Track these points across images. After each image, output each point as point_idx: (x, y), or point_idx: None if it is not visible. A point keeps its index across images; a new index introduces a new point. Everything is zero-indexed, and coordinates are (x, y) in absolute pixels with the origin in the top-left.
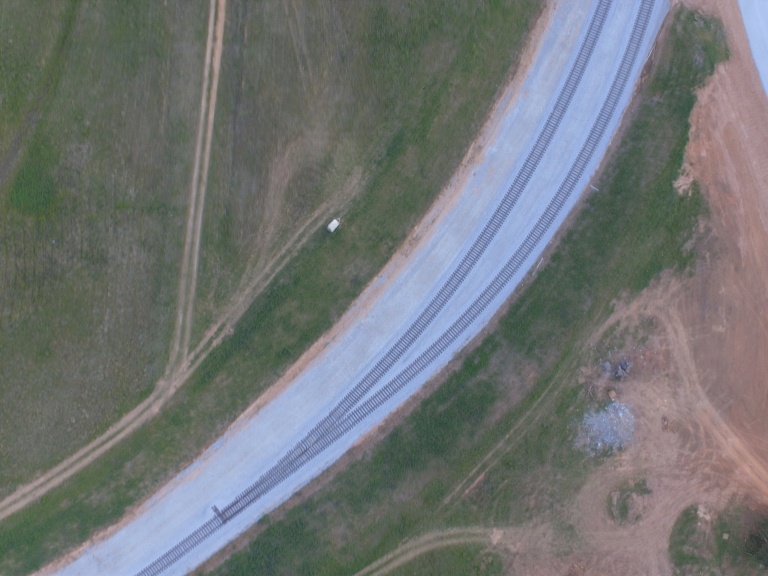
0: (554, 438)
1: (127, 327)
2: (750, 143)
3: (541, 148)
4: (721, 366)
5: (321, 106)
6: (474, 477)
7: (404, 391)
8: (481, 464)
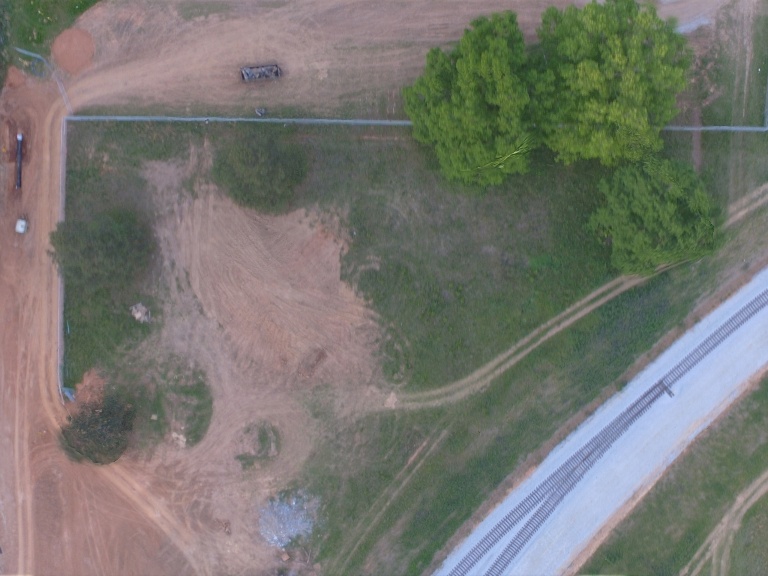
0: (341, 506)
1: None
2: None
3: None
4: None
5: None
6: (419, 459)
7: (490, 526)
8: (413, 472)
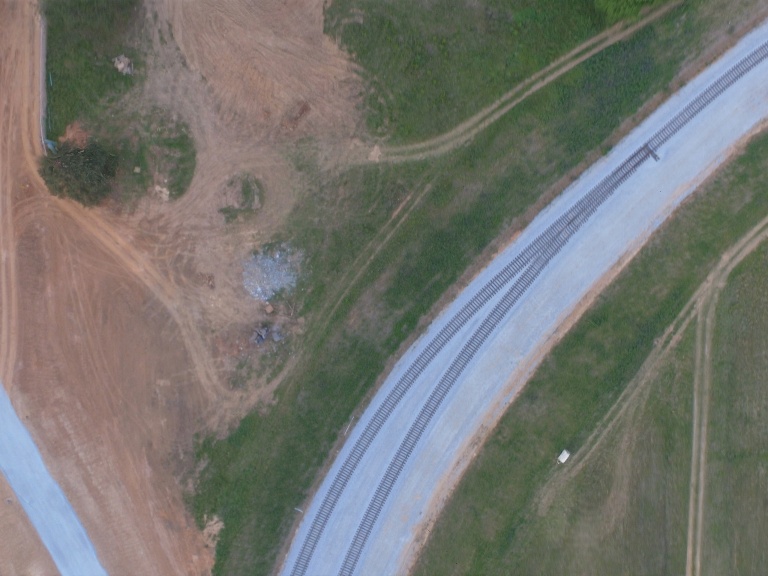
0: (325, 259)
1: (759, 337)
2: (148, 571)
3: (357, 545)
4: (158, 345)
5: (584, 572)
6: (403, 213)
7: (475, 290)
8: (397, 227)
